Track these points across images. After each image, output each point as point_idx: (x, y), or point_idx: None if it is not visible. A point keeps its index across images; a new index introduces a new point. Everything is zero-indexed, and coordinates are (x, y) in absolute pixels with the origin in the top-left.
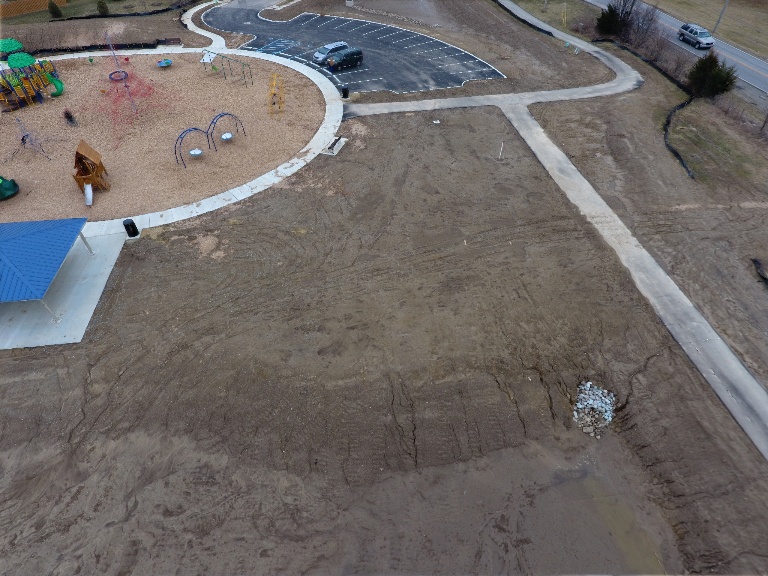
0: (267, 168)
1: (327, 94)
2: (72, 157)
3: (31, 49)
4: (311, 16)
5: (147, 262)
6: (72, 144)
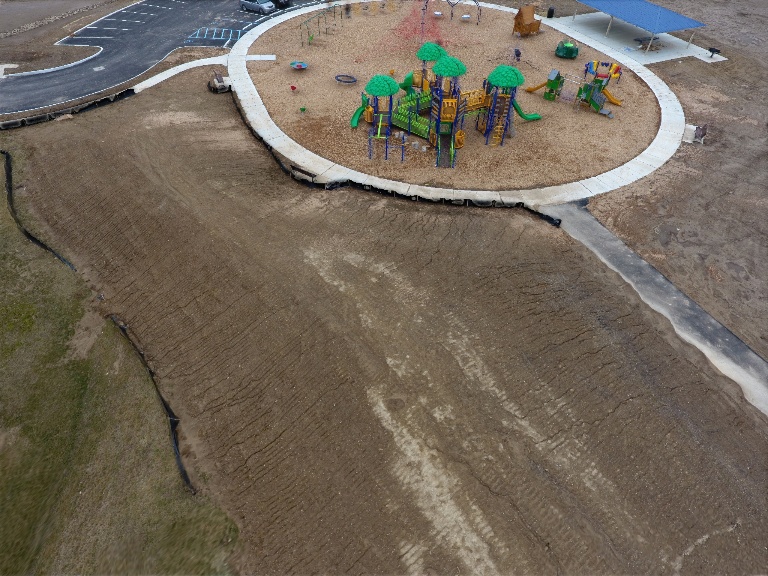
0: (460, 4)
1: (341, 4)
2: (505, 53)
3: (268, 174)
4: (75, 39)
5: (562, 11)
6: (490, 58)
